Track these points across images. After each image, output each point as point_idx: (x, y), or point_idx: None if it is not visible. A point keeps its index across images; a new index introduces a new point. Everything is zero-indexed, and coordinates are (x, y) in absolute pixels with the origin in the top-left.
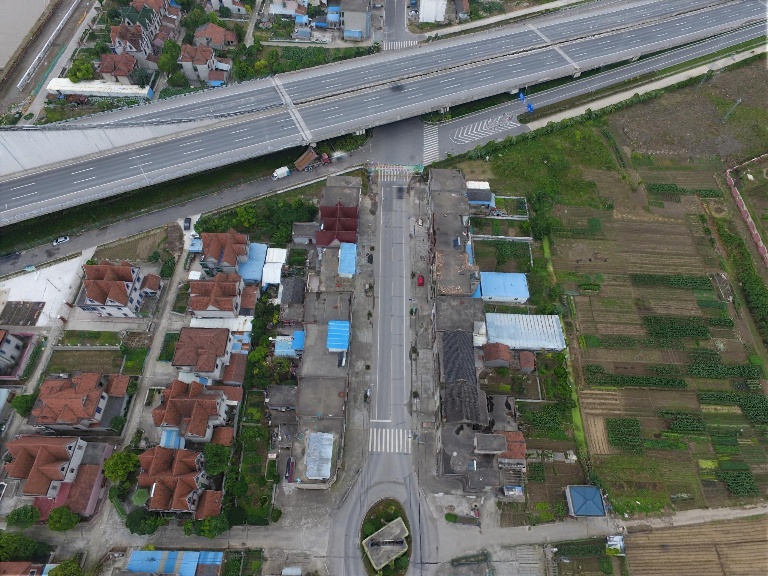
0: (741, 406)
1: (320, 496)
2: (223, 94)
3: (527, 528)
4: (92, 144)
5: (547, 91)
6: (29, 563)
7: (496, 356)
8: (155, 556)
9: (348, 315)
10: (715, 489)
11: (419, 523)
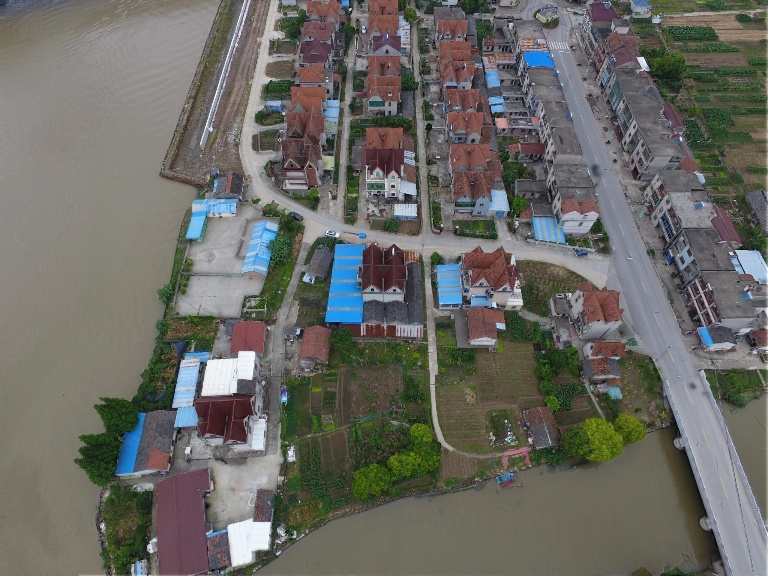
0: None
1: None
2: None
3: None
4: None
5: None
6: None
7: None
8: None
9: None
10: None
11: (563, 3)
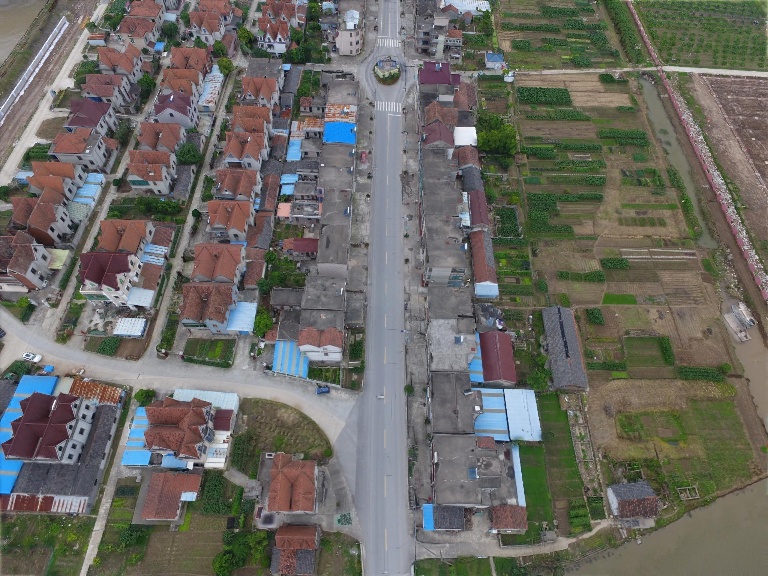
0: (590, 38)
1: (351, 58)
2: None
3: None
4: None
5: None
6: None
7: (449, 9)
8: None
9: None
10: (568, 65)
11: (404, 56)
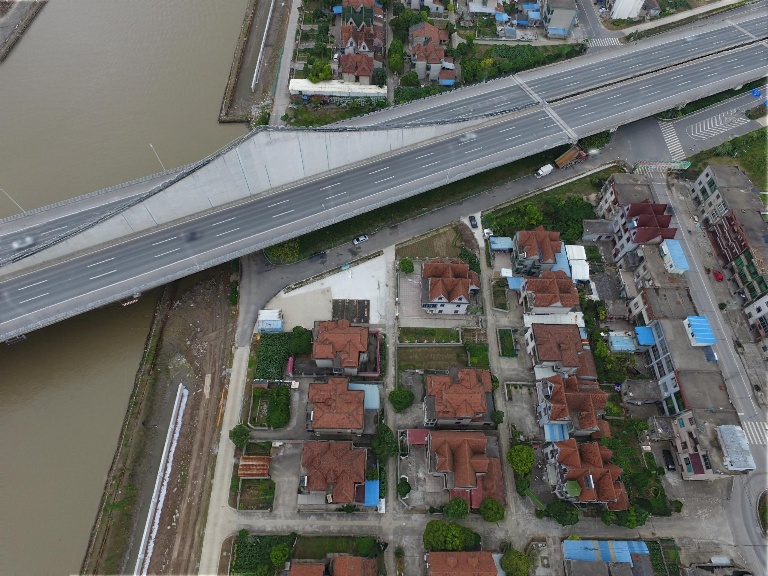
0: None
1: (706, 487)
2: (474, 93)
3: None
4: (388, 144)
5: (764, 87)
6: (489, 552)
7: None
8: (587, 545)
9: (694, 310)
10: None
11: None
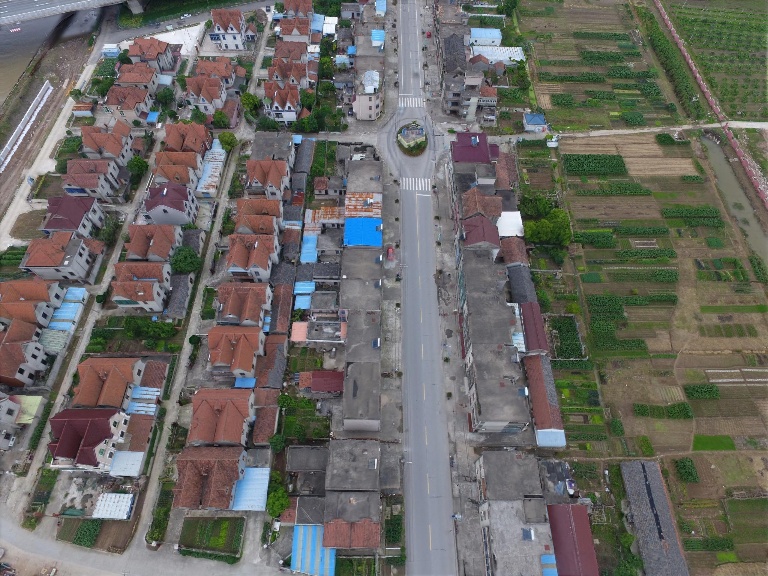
0: (640, 89)
1: (370, 123)
2: None
3: (498, 136)
4: None
5: None
6: None
7: (479, 60)
8: None
9: None
10: (618, 123)
11: (432, 122)
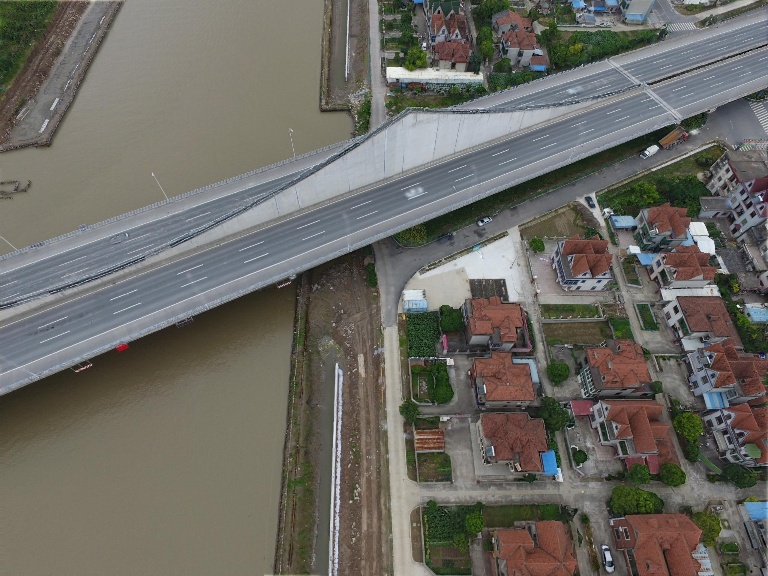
0: None
1: None
2: (574, 77)
3: None
4: (508, 126)
5: None
6: (683, 514)
7: None
8: (767, 506)
9: None
10: None
11: None
